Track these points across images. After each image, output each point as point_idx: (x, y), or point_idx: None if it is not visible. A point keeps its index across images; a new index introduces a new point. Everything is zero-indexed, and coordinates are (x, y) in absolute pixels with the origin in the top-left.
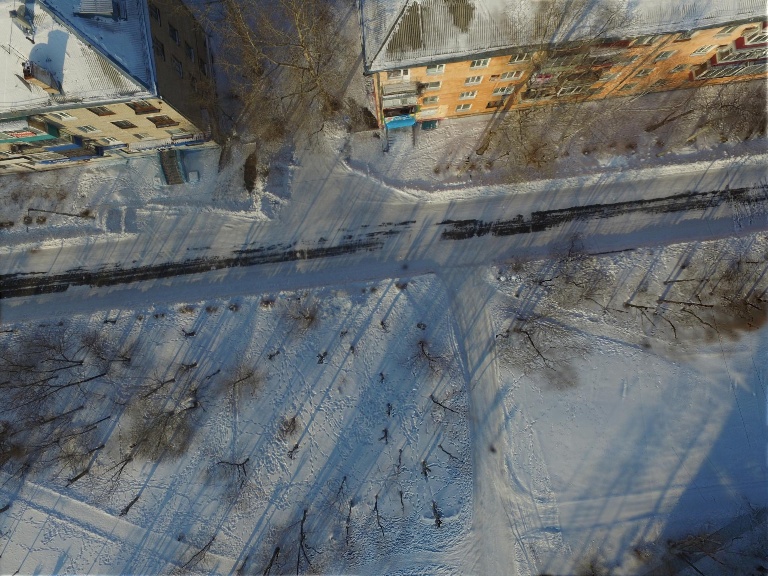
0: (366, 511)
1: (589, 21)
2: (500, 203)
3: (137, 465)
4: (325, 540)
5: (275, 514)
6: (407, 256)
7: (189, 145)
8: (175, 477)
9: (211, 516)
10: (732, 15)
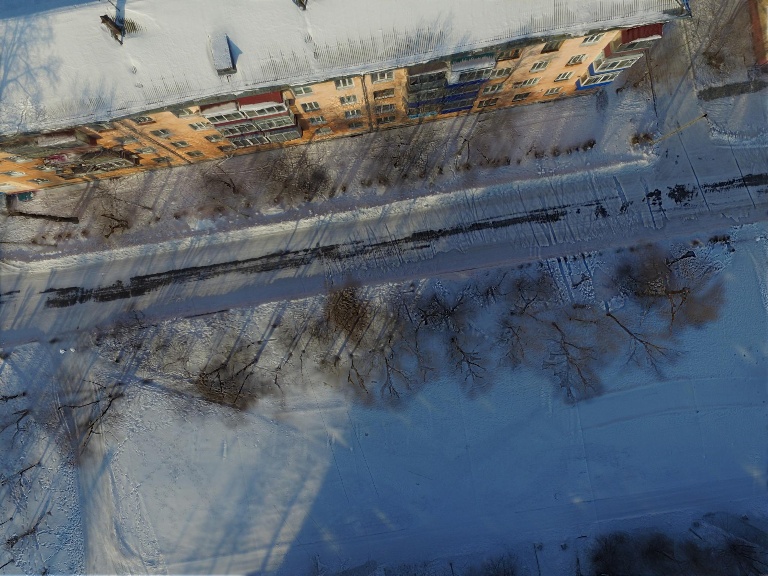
0: None
1: (1, 118)
2: (99, 270)
3: None
4: None
5: None
6: (13, 326)
7: None
8: None
9: None
10: (143, 105)
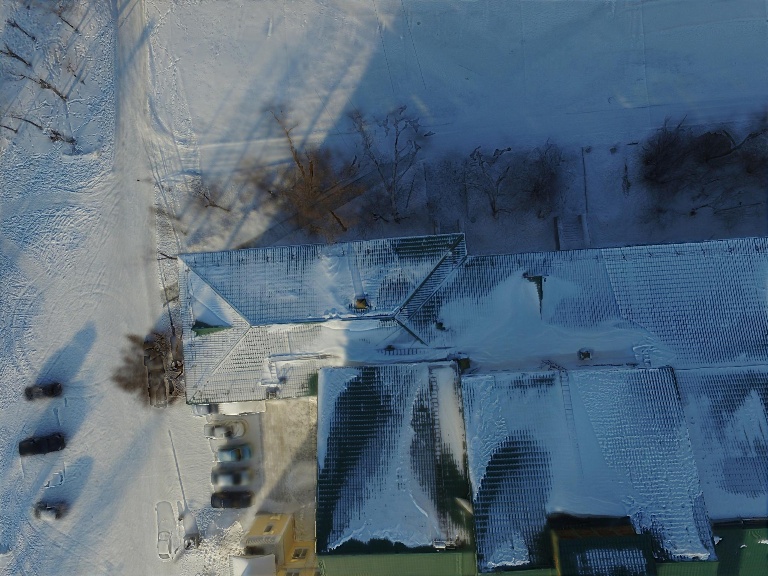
0: (5, 146)
1: None
2: None
3: None
4: None
5: None
6: None
7: None
8: None
9: None
10: None
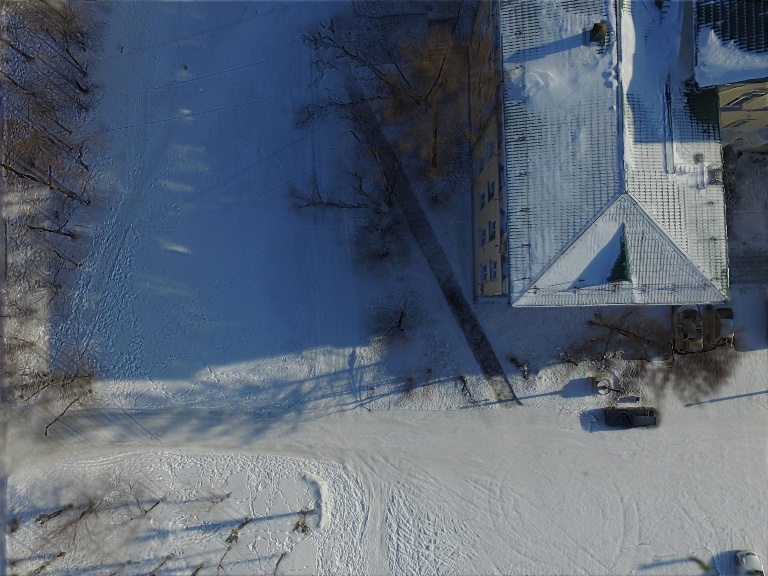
0: None
1: None
2: None
3: None
4: None
5: None
6: None
7: None
8: None
9: None
10: None
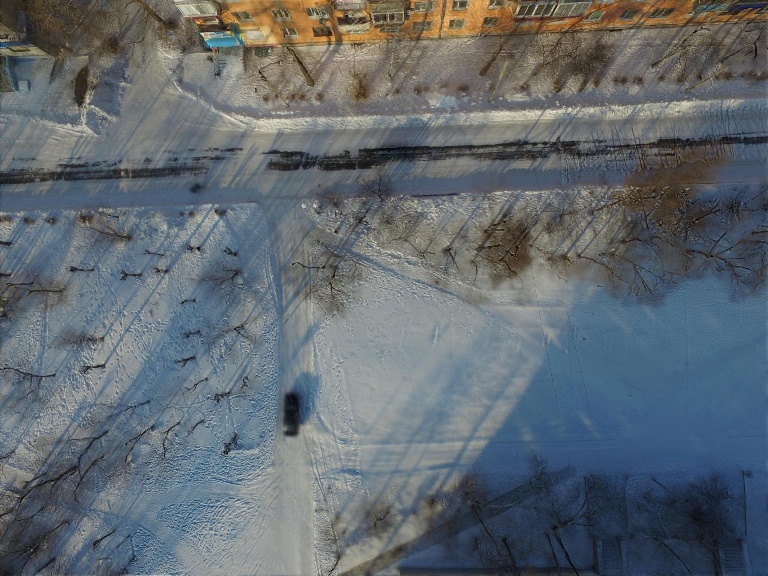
0: None
1: None
2: (328, 137)
3: None
4: (124, 462)
5: (77, 432)
6: (231, 183)
7: (15, 51)
8: None
9: (13, 429)
10: None
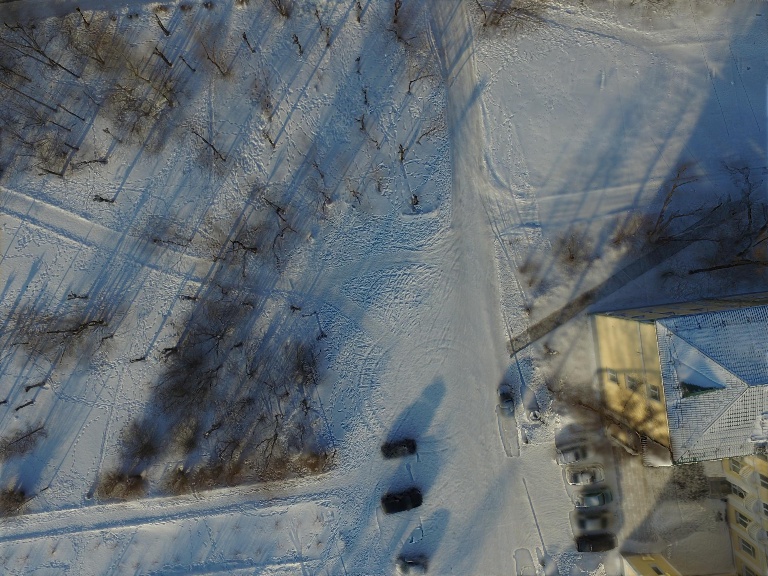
0: (344, 209)
1: None
2: None
3: (112, 167)
4: (303, 239)
5: (252, 215)
6: None
7: None
8: (151, 179)
9: (187, 218)
10: None
